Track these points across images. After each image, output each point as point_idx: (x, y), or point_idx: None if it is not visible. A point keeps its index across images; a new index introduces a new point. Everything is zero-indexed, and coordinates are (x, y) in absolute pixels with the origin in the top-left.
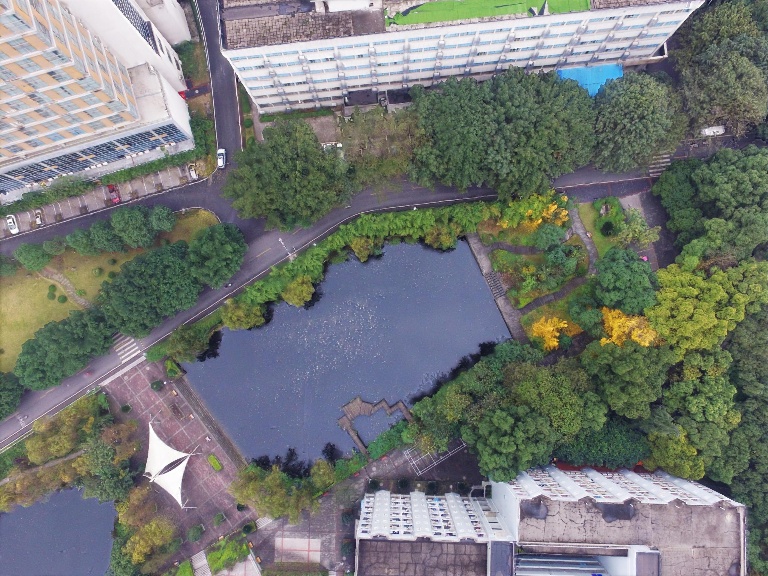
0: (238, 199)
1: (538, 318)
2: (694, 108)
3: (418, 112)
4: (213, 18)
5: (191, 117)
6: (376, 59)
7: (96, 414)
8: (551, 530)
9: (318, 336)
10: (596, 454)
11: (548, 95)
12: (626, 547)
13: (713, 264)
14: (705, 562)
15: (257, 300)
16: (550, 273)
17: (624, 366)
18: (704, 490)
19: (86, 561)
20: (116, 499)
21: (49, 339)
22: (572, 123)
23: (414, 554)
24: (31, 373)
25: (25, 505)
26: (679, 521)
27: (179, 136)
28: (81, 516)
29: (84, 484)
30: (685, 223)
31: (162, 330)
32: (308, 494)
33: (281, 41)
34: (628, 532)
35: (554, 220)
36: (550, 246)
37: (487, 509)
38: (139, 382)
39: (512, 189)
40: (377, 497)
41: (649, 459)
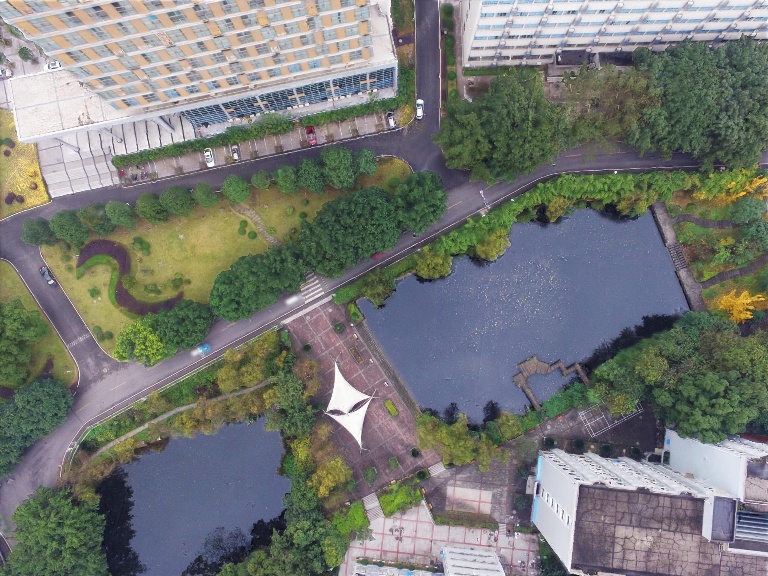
0: (456, 146)
1: (721, 292)
2: None
3: (651, 72)
4: None
5: None
6: (615, 16)
7: None
8: None
9: (499, 293)
10: None
11: None
12: None
13: None
14: None
15: (451, 250)
16: (747, 247)
17: None
18: None
19: (251, 495)
20: None
21: (248, 271)
22: None
23: (631, 504)
24: (227, 303)
25: (207, 433)
26: None
27: (384, 83)
28: (249, 451)
29: (254, 420)
30: None
31: (348, 274)
32: (492, 444)
33: None
34: None
35: (753, 195)
36: (749, 220)
37: (677, 472)
38: (321, 323)
39: (726, 158)
40: (558, 453)
41: None
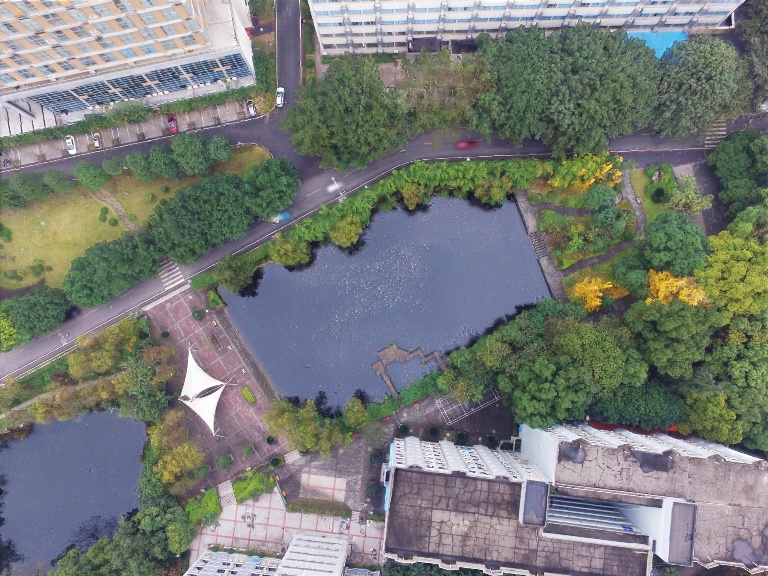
0: (298, 132)
1: (580, 280)
2: (761, 75)
3: (485, 57)
4: None
5: (254, 54)
6: (448, 2)
7: (136, 337)
8: (588, 475)
9: (360, 280)
10: (632, 412)
11: (615, 51)
12: (662, 497)
13: (767, 232)
14: (739, 521)
15: (305, 237)
16: (598, 233)
17: (672, 322)
18: (741, 453)
19: (113, 482)
20: None
21: (99, 257)
22: (637, 80)
23: (448, 488)
24: (79, 289)
25: (61, 418)
26: (717, 477)
27: (241, 70)
28: (112, 438)
29: (117, 407)
30: (739, 192)
31: (207, 260)
32: (340, 431)
33: None
34: (664, 484)
35: (606, 182)
36: (600, 207)
37: None
38: (181, 310)
39: (569, 144)
40: (407, 440)
41: (685, 423)
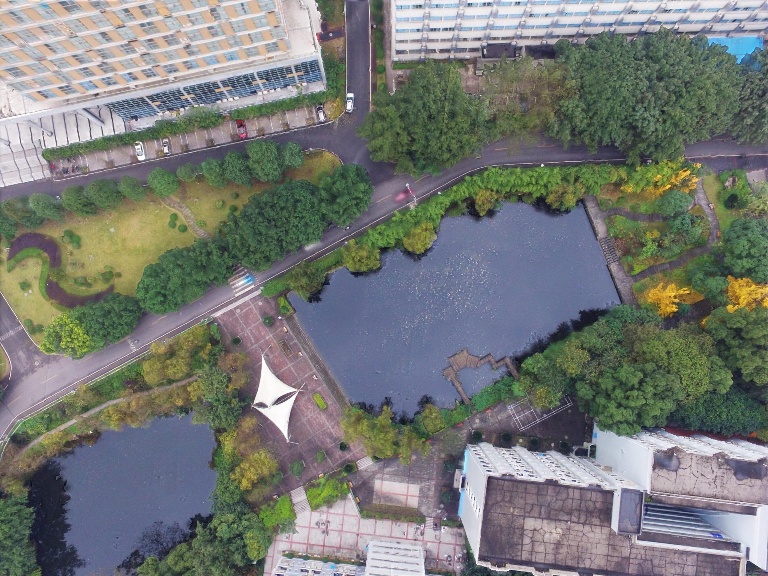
0: (377, 138)
1: (651, 286)
2: None
3: (568, 64)
4: None
5: (323, 59)
6: (531, 8)
7: (206, 344)
8: (682, 483)
9: (429, 286)
10: (714, 419)
11: (698, 58)
12: (757, 505)
13: None
14: None
15: (378, 243)
16: (673, 240)
17: (761, 329)
18: None
19: (182, 488)
20: (221, 428)
21: (174, 264)
22: (722, 87)
23: (540, 496)
24: (153, 296)
25: (134, 425)
26: None
27: (313, 76)
28: (180, 444)
29: (185, 413)
30: None
31: (278, 267)
32: (416, 437)
33: None
34: (759, 491)
35: (680, 188)
36: (675, 213)
37: (598, 465)
38: (251, 316)
39: (648, 151)
40: (483, 447)
41: (765, 429)
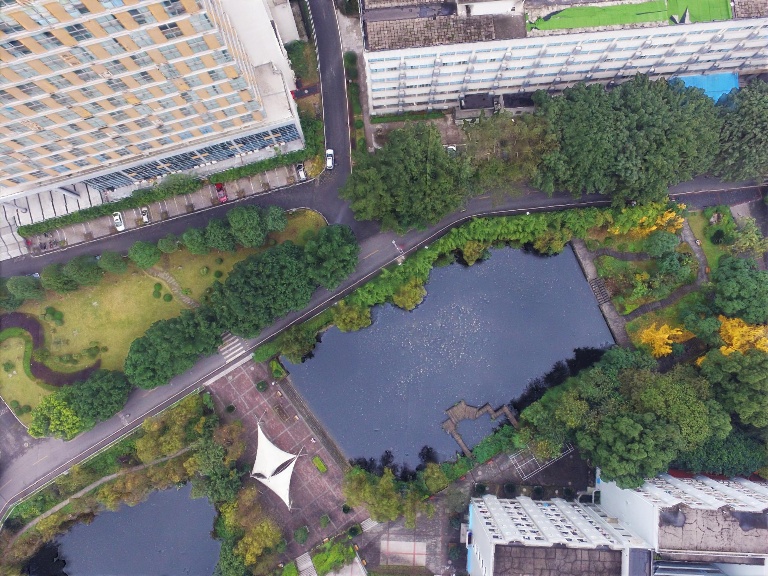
0: (360, 201)
1: (644, 325)
2: None
3: (548, 117)
4: (324, 18)
5: (300, 117)
6: (507, 63)
7: (200, 414)
8: (689, 538)
9: (422, 339)
10: (716, 462)
11: (676, 103)
12: (765, 556)
13: None
14: None
15: (368, 302)
16: (663, 280)
17: (756, 375)
18: None
19: (185, 561)
20: None
21: (161, 338)
22: (701, 131)
23: (548, 560)
24: (141, 372)
25: (131, 504)
26: None
27: (291, 136)
28: (180, 516)
29: (183, 484)
30: None
31: (268, 330)
32: None
33: (423, 44)
34: (765, 541)
35: (666, 227)
36: (663, 253)
37: (604, 515)
38: (243, 382)
39: (632, 196)
40: (487, 501)
41: (766, 468)
